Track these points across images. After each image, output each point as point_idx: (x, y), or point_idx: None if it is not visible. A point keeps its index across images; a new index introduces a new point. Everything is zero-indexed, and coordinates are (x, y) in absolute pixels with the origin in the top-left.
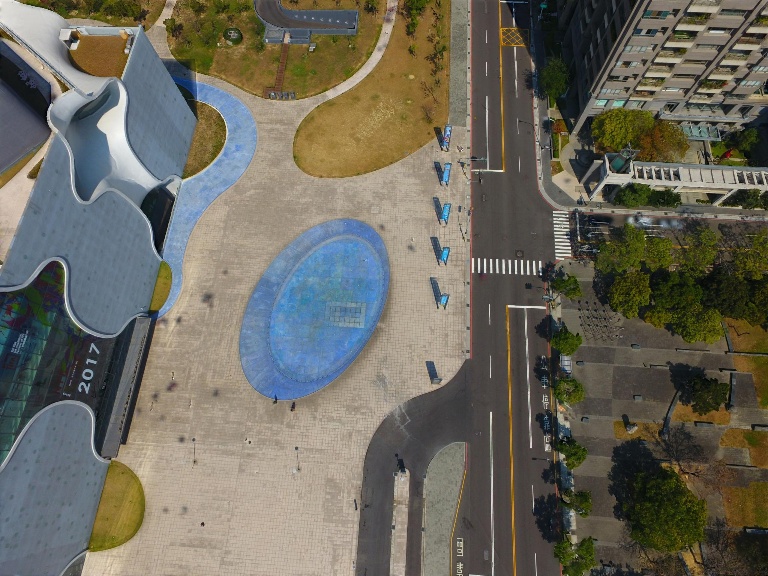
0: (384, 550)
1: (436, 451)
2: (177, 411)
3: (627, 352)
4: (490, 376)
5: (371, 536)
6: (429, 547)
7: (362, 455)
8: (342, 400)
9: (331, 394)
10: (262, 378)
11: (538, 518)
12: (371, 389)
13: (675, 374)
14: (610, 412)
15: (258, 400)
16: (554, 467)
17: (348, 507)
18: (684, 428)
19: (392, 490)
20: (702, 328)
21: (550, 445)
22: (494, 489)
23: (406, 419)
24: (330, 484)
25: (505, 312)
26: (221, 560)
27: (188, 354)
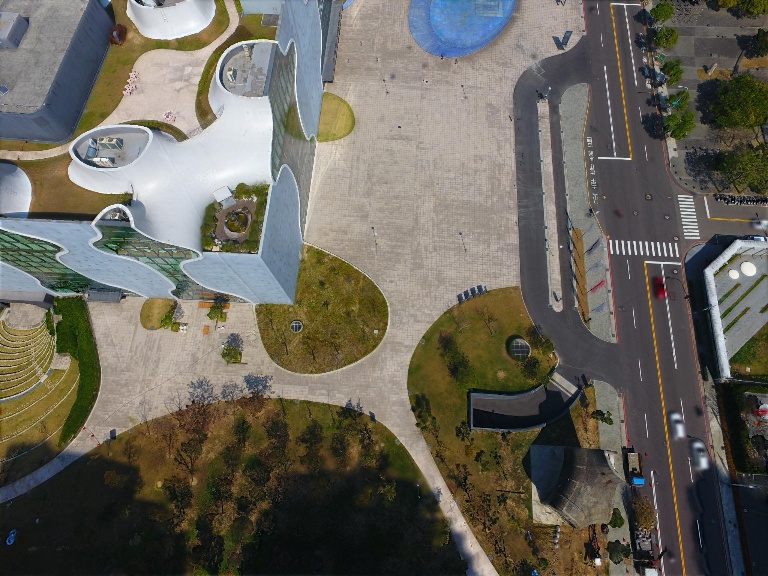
0: (535, 143)
1: (566, 89)
2: (368, 64)
3: (704, 29)
4: (602, 45)
5: (524, 136)
6: (567, 141)
7: (511, 91)
8: (492, 58)
9: (484, 55)
10: (430, 45)
11: (645, 126)
12: (513, 53)
13: (741, 41)
14: (694, 64)
15: (429, 57)
16: (654, 97)
17: (505, 120)
18: (749, 72)
19: (536, 110)
20: (762, 1)
21: (650, 85)
22: (611, 109)
23: (541, 71)
24: (490, 107)
25: (610, 7)
26: (417, 147)
27: (370, 31)
